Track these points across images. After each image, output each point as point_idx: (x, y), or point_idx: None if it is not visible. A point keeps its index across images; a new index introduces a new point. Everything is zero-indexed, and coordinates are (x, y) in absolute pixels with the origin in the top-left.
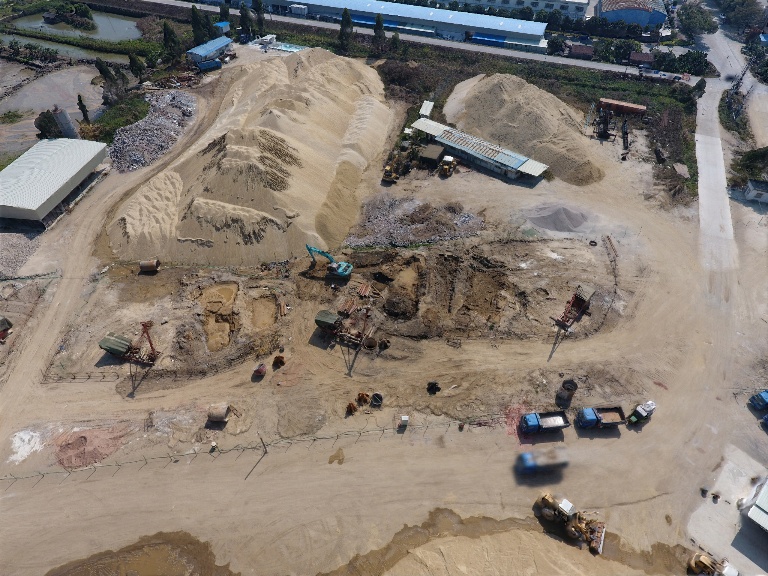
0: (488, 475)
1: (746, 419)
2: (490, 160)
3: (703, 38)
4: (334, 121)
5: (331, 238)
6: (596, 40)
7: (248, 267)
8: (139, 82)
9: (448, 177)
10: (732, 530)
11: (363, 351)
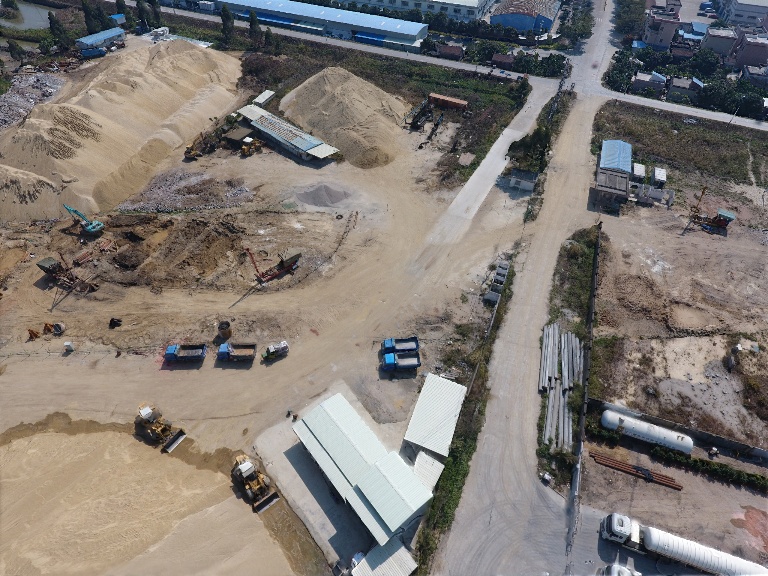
0: (116, 391)
1: (369, 361)
2: (287, 143)
3: (585, 43)
4: (162, 104)
5: (105, 202)
6: (479, 42)
7: (20, 223)
8: (20, 65)
9: (248, 157)
10: (292, 442)
11: (73, 293)
